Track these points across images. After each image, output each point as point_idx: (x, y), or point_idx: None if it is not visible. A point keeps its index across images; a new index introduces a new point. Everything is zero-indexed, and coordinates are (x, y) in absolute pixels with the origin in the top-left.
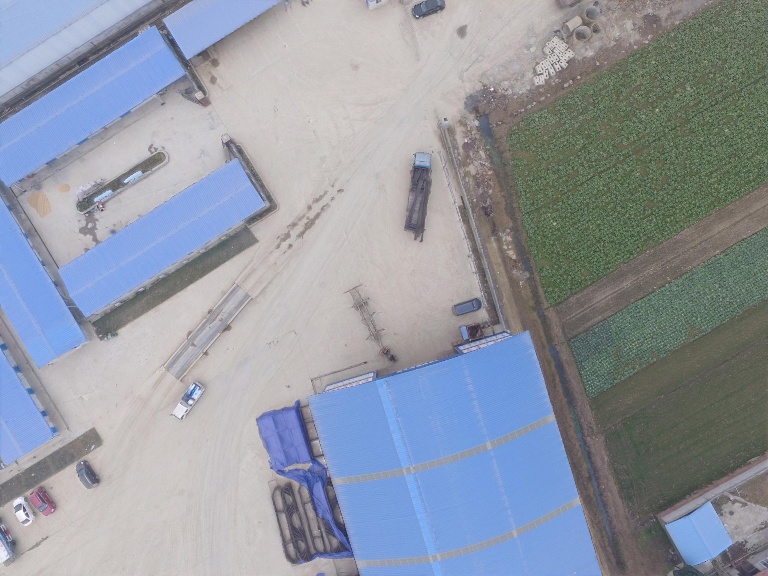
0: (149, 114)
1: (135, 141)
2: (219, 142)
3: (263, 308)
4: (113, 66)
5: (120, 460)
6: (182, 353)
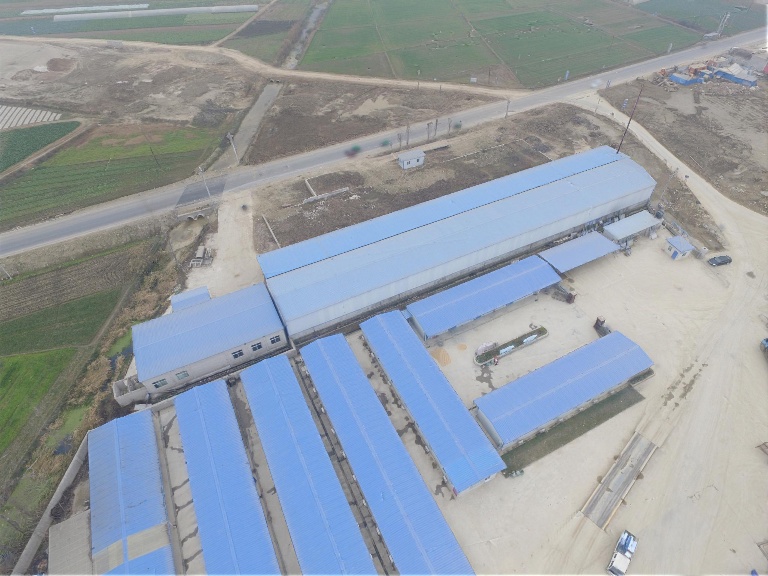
0: (526, 305)
1: (518, 321)
2: (586, 326)
3: (671, 459)
4: (509, 272)
5: None
6: (599, 498)
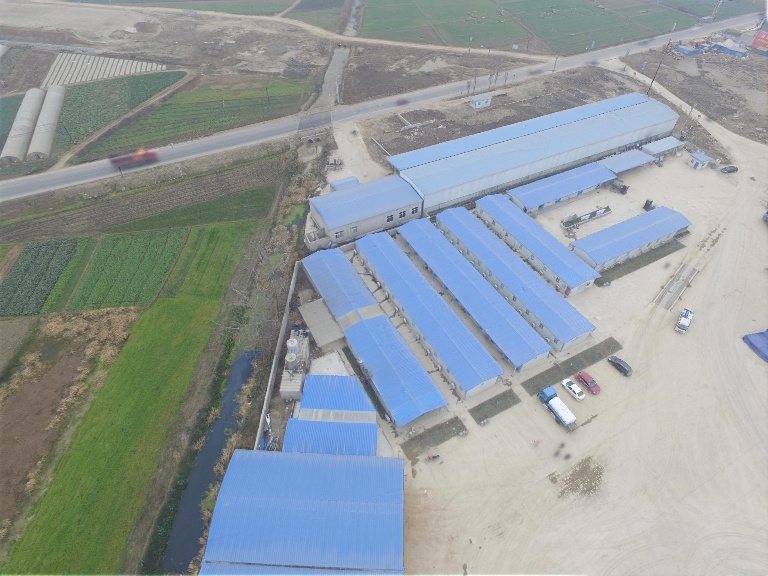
0: (592, 195)
1: (587, 204)
2: (638, 207)
3: (708, 277)
4: None
5: (641, 360)
6: (664, 296)
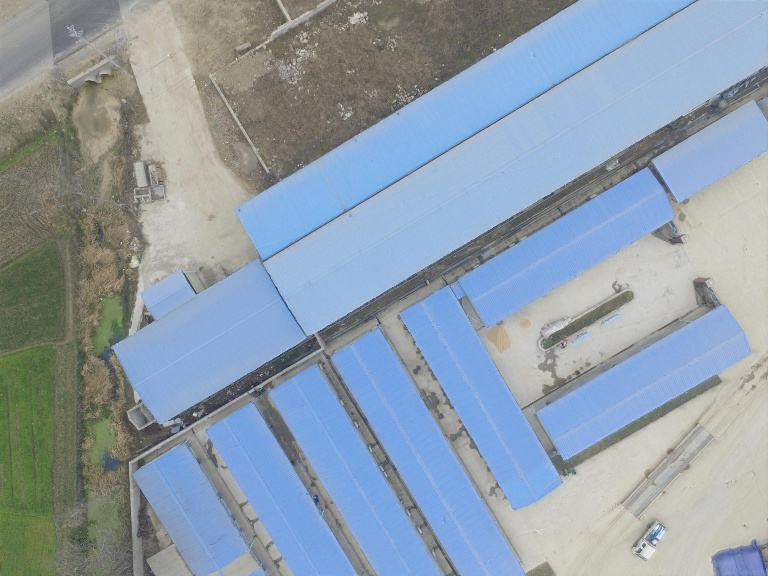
0: None
1: (599, 277)
2: (685, 280)
3: (723, 448)
4: (605, 209)
5: None
6: (642, 492)
